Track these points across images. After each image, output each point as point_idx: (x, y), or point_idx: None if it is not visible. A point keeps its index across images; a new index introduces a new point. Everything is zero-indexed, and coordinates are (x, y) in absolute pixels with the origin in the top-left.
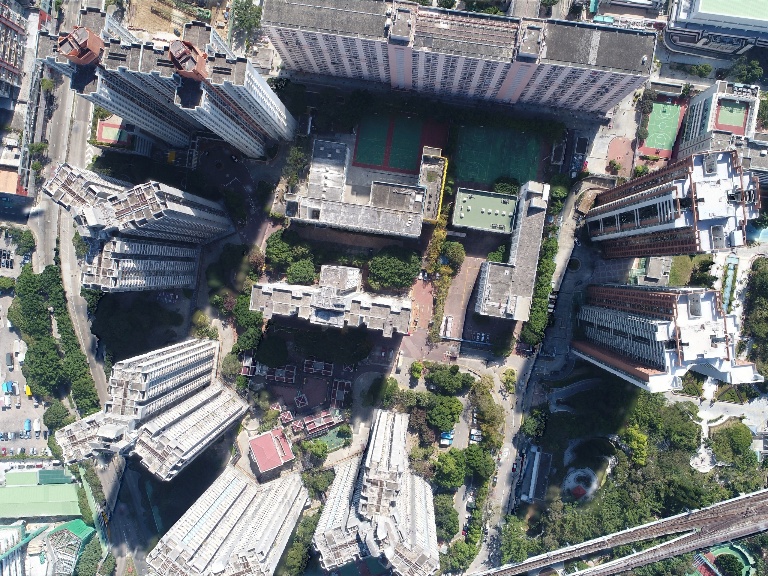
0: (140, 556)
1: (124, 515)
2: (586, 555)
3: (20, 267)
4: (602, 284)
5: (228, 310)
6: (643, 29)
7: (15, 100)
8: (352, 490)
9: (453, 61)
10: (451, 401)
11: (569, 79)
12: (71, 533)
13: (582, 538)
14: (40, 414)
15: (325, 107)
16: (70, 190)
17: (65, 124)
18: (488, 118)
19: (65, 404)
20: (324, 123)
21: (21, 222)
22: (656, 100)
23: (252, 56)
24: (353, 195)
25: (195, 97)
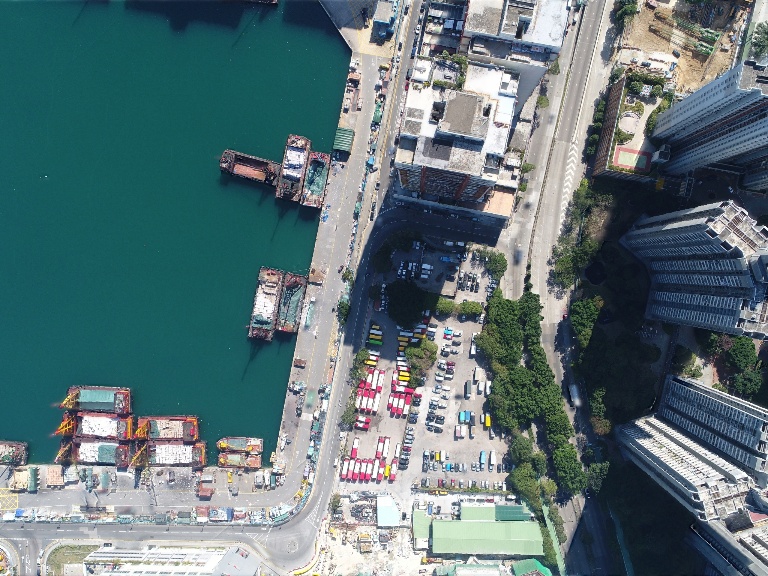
0: None
1: (579, 557)
2: None
3: (485, 291)
4: None
5: (725, 350)
6: None
7: (518, 118)
8: None
9: None
10: None
11: None
12: (542, 575)
13: None
14: (495, 446)
15: None
16: (738, 230)
17: (545, 144)
18: None
19: (528, 438)
20: None
21: (490, 244)
22: None
23: None
24: None
25: None
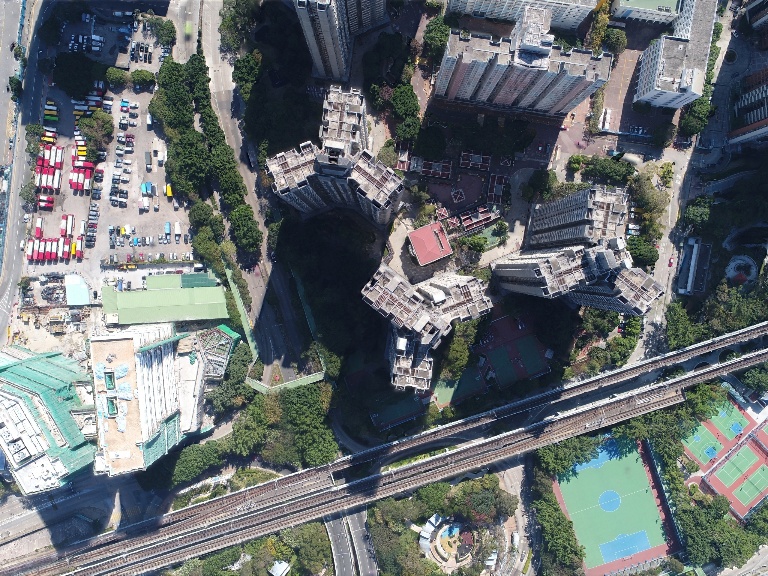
0: (287, 363)
1: (270, 321)
2: (741, 349)
3: (159, 62)
4: None
5: (385, 99)
6: None
7: None
8: None
9: None
10: None
11: None
12: (222, 332)
13: (745, 323)
14: (180, 217)
15: None
16: None
17: None
18: None
19: (209, 204)
20: None
21: (160, 13)
22: None
23: None
24: None
25: None
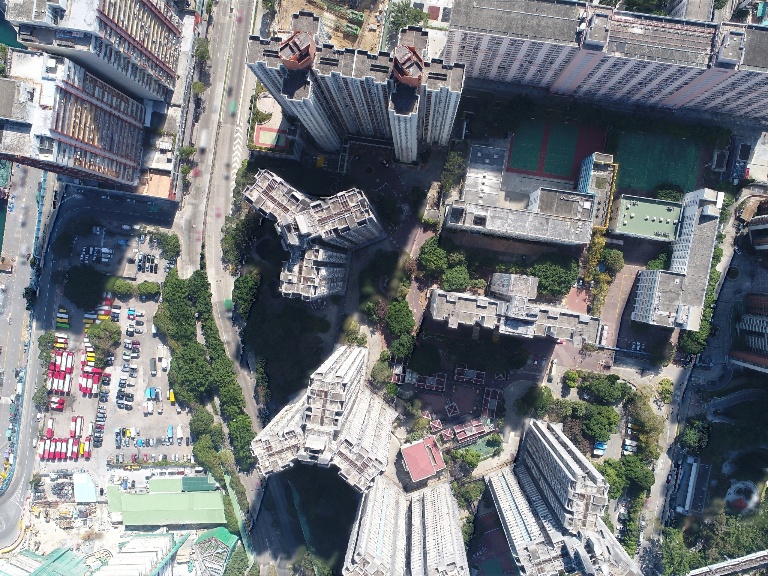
0: (283, 565)
1: (267, 523)
2: None
3: (164, 272)
4: (767, 293)
5: (381, 317)
6: None
7: (169, 103)
8: (527, 502)
9: (643, 66)
10: (609, 411)
11: (757, 85)
12: (219, 541)
13: (744, 551)
14: (182, 420)
15: (484, 112)
16: (271, 197)
17: (212, 128)
18: (652, 124)
19: (209, 411)
20: (482, 128)
21: (166, 226)
22: None
23: None
24: (506, 201)
25: (409, 103)
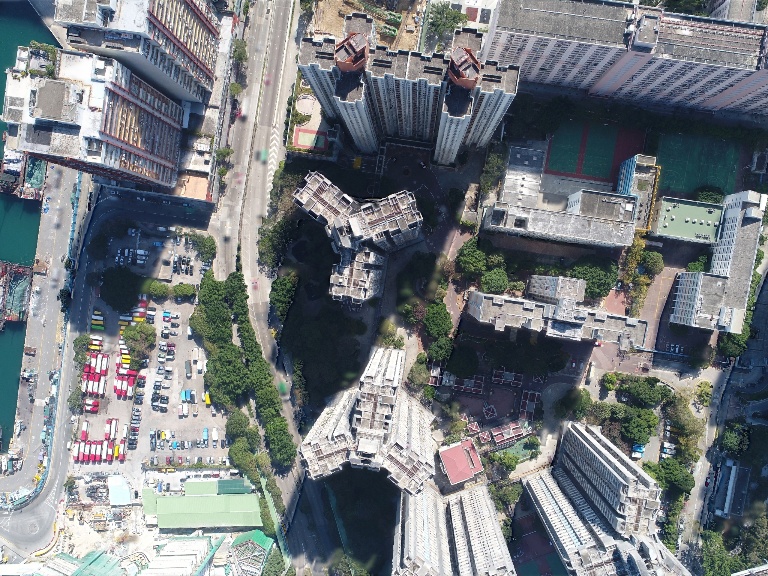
0: (318, 568)
1: (303, 526)
2: None
3: (200, 274)
4: None
5: (419, 319)
6: None
7: (207, 105)
8: (571, 505)
9: (690, 68)
10: (648, 414)
11: None
12: (256, 544)
13: None
14: (218, 423)
15: (523, 113)
16: (322, 199)
17: (248, 129)
18: (692, 126)
19: (245, 413)
20: (521, 130)
21: (202, 228)
22: None
23: None
24: (544, 203)
25: (463, 105)
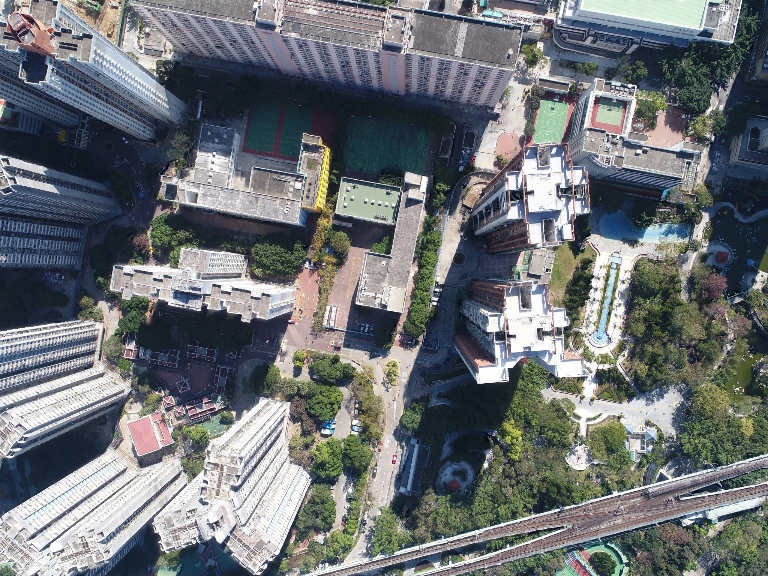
0: None
1: (4, 495)
2: (463, 549)
3: None
4: None
5: (111, 292)
6: (530, 25)
7: None
8: None
9: (323, 48)
10: (330, 391)
11: (442, 71)
12: None
13: (455, 531)
14: None
15: (213, 91)
16: None
17: None
18: (375, 108)
19: None
20: (212, 107)
21: None
22: (545, 97)
23: (144, 37)
24: (242, 181)
25: (41, 72)
